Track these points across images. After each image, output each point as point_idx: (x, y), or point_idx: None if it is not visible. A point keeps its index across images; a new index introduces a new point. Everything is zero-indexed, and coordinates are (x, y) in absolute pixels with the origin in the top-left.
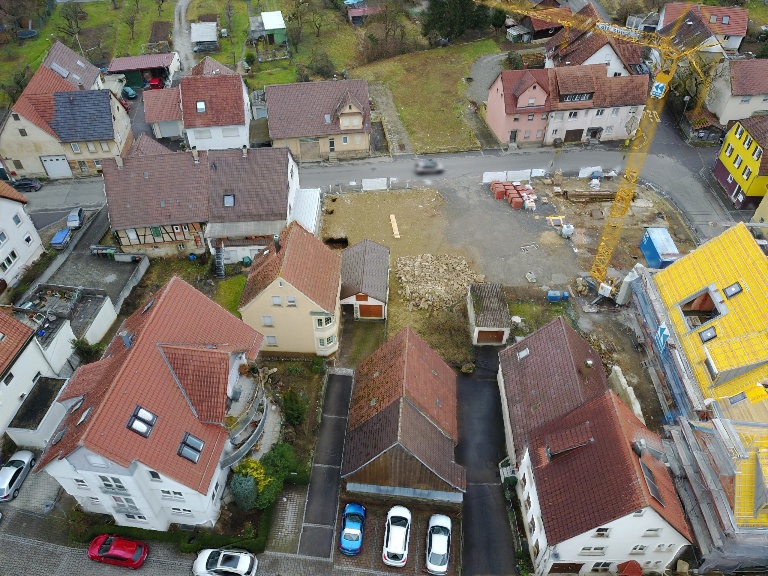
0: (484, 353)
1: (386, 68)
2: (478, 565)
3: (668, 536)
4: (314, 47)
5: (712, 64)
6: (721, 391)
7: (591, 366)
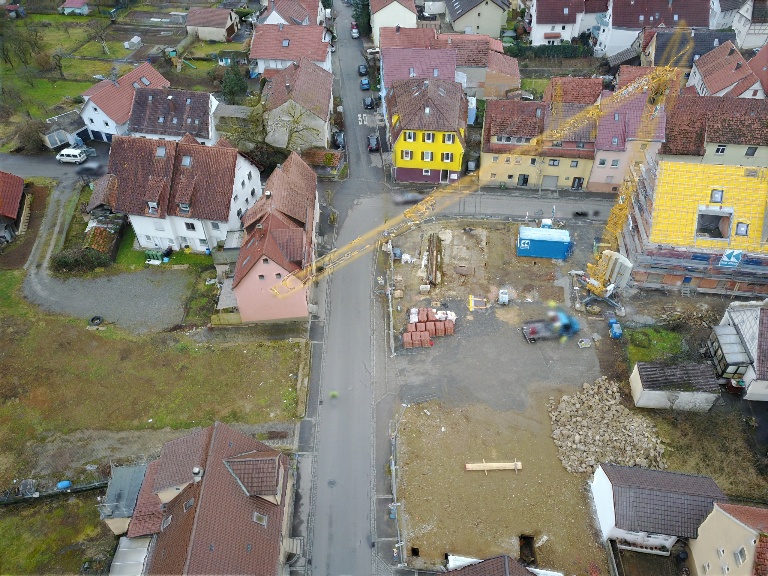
0: None
1: None
2: None
3: None
4: None
5: (269, 113)
6: None
7: None
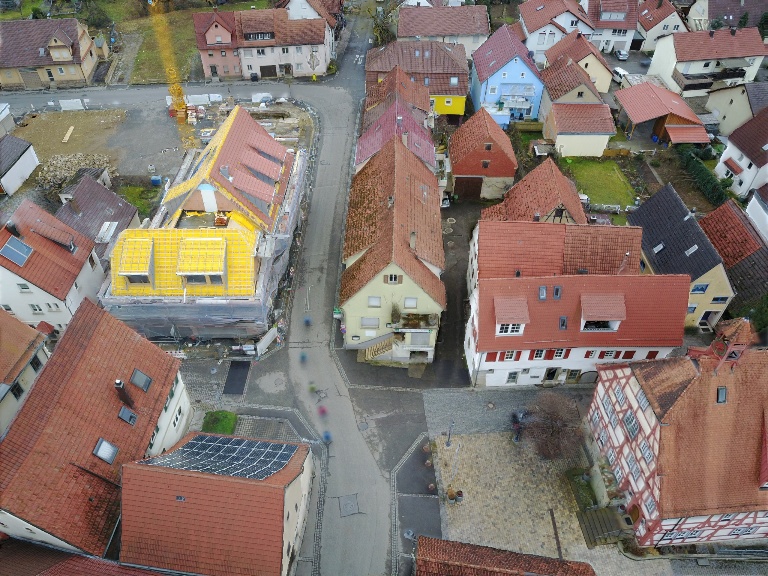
0: None
1: (152, 21)
2: None
3: (39, 293)
4: (106, 5)
5: None
6: None
7: (72, 200)
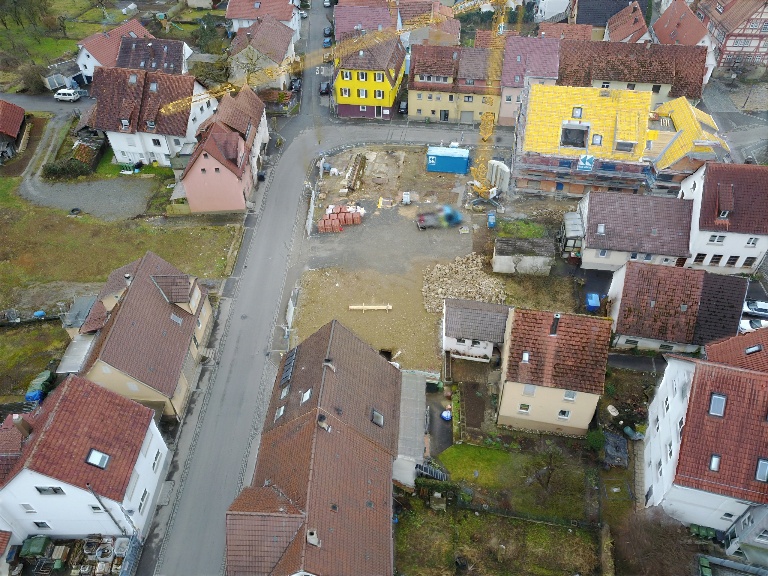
0: (557, 271)
1: None
2: (759, 297)
3: None
4: None
5: (231, 57)
6: (639, 151)
7: None
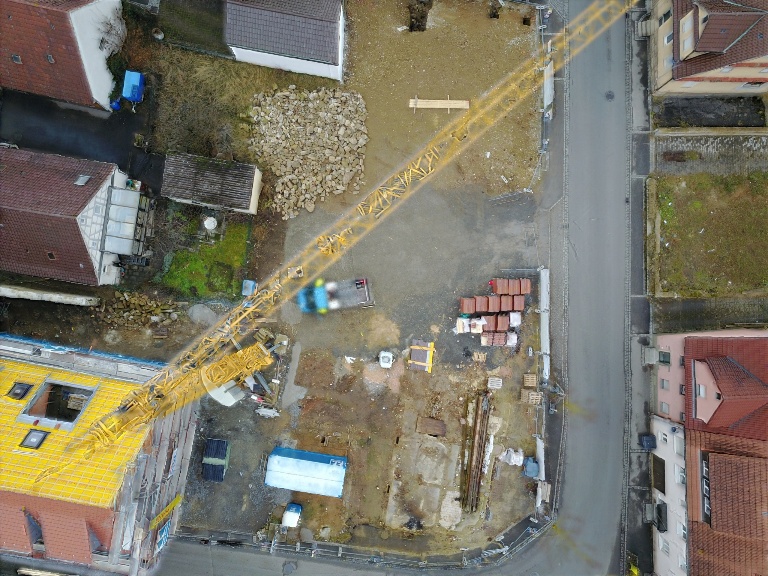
0: None
1: None
2: None
3: None
4: None
5: None
6: None
7: None
